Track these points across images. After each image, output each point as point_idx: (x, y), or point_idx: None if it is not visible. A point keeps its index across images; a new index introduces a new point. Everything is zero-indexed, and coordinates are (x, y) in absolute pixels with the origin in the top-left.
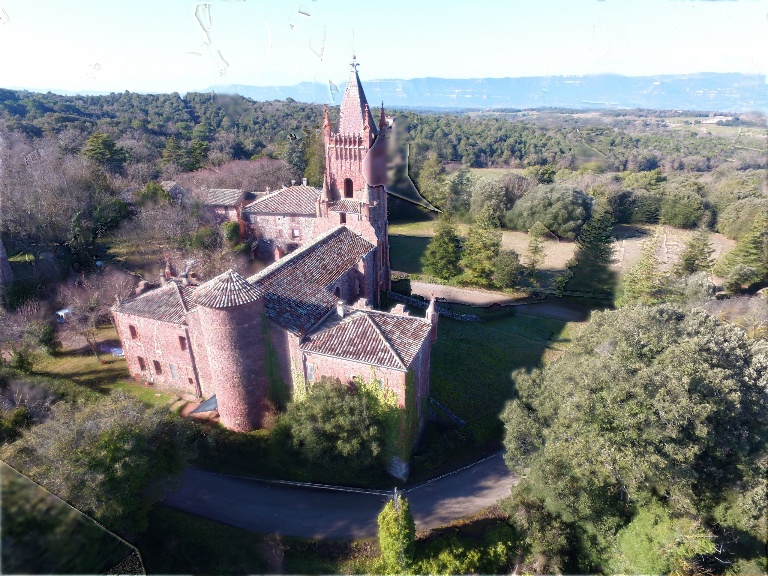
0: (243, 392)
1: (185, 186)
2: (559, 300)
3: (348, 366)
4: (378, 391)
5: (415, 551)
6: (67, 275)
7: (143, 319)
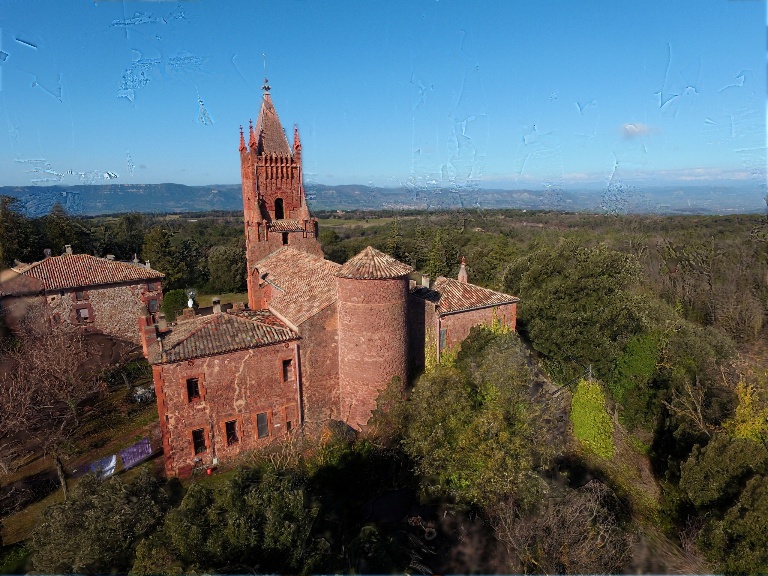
0: (405, 380)
1: None
2: None
3: (476, 316)
4: (498, 330)
5: None
6: None
7: (220, 358)
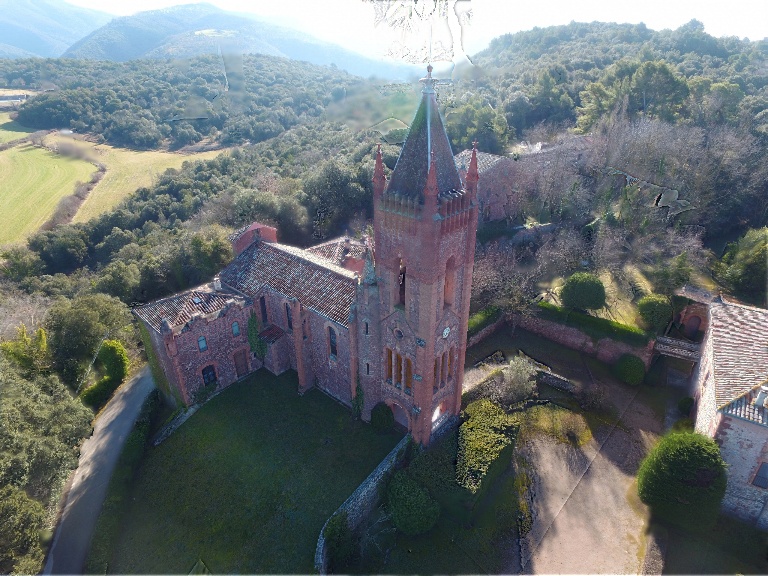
0: None
1: (564, 212)
2: None
3: None
4: None
5: (113, 383)
6: (490, 239)
7: None
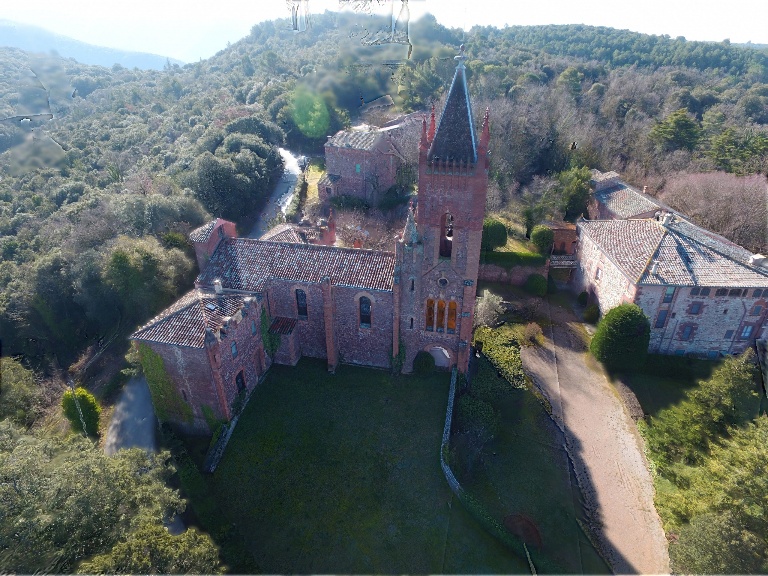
0: None
1: None
2: None
3: None
4: None
5: None
6: (390, 209)
7: None
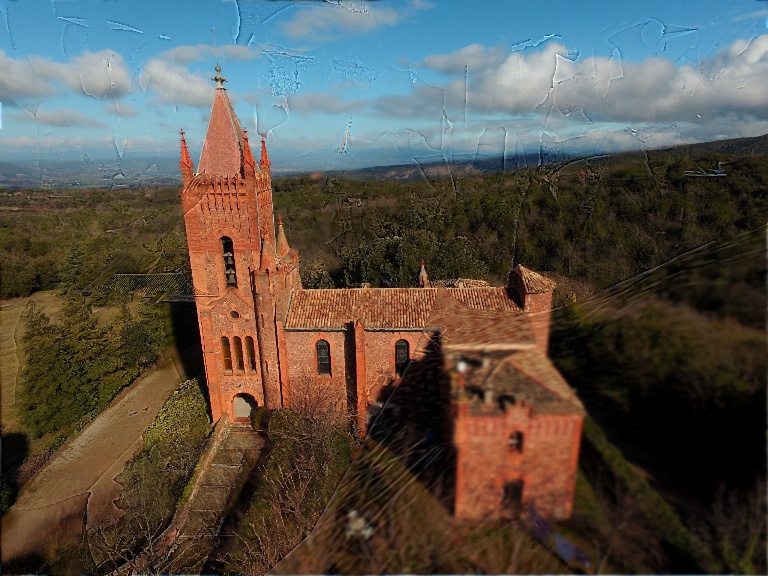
0: None
1: None
2: (172, 348)
3: None
4: None
5: None
6: None
7: None
